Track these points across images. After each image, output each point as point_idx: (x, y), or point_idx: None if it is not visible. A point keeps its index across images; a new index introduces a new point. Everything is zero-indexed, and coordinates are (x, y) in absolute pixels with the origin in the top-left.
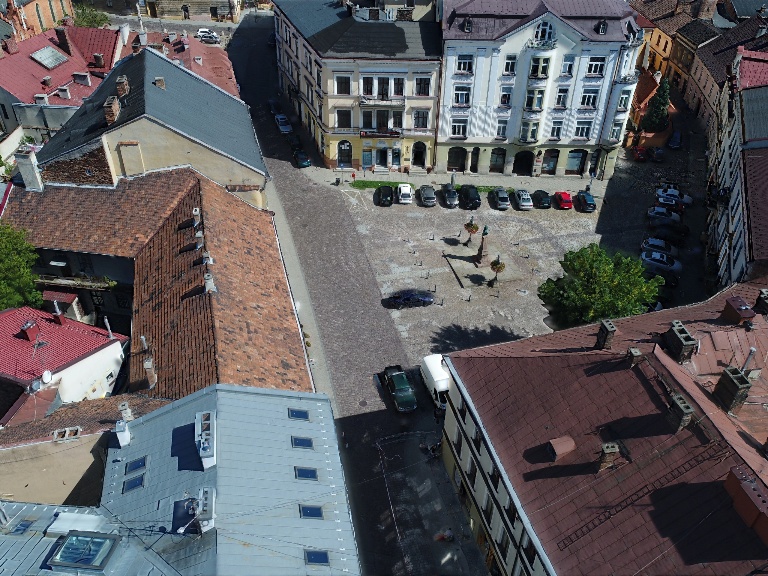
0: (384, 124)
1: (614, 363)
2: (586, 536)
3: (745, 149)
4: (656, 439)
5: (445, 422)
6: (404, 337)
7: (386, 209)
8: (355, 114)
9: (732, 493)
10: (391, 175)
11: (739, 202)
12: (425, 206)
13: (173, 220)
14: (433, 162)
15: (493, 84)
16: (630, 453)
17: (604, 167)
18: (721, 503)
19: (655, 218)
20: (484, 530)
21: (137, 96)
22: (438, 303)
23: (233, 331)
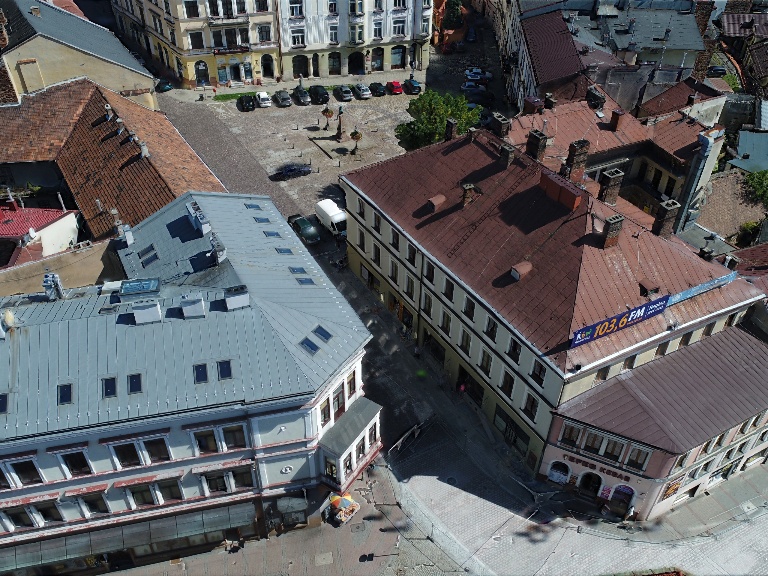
0: (233, 41)
1: (460, 143)
2: (464, 244)
3: (522, 19)
4: (496, 176)
5: (347, 234)
6: (295, 198)
7: (251, 113)
8: (206, 35)
9: (545, 187)
10: (247, 87)
11: (525, 57)
12: (283, 106)
13: (83, 122)
14: (281, 72)
15: None
16: (481, 189)
17: (421, 59)
18: (540, 196)
19: (467, 91)
20: (393, 293)
21: (20, 23)
22: (315, 172)
23: (175, 180)
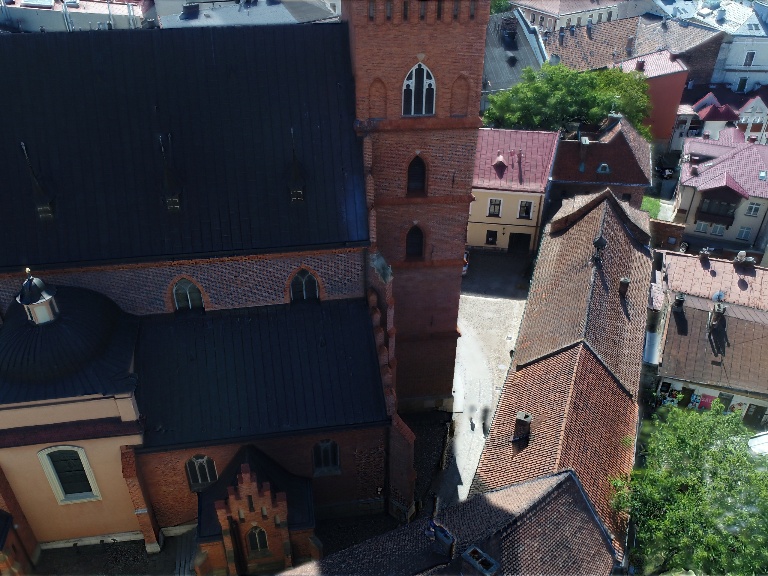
0: None
1: None
2: None
3: None
4: None
5: None
6: None
7: None
8: None
9: None
10: None
11: None
12: None
13: None
14: None
15: None
16: None
17: None
18: None
19: None
20: None
21: None
22: None
23: None
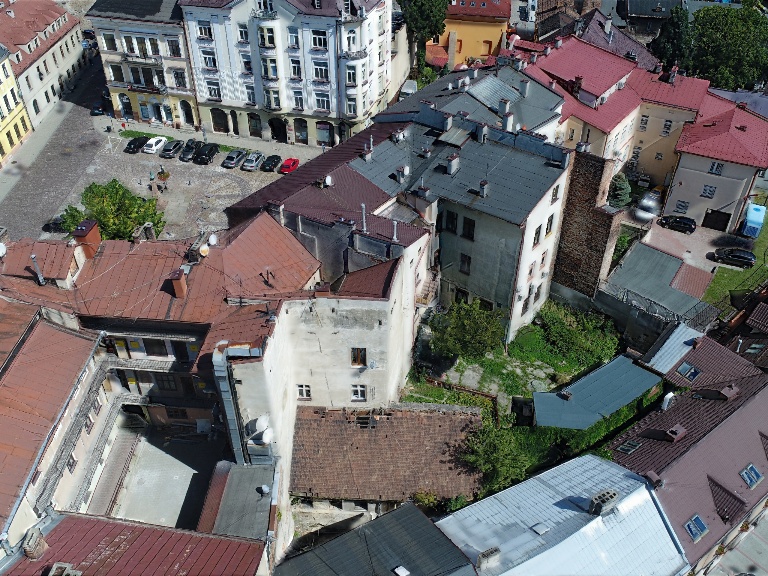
0: (151, 81)
1: None
2: None
3: (375, 123)
4: None
5: None
6: None
7: (129, 155)
8: (125, 69)
9: None
10: (163, 129)
11: None
12: (164, 157)
13: None
14: (199, 121)
15: (232, 50)
16: None
17: None
18: None
19: None
20: None
21: None
22: None
23: None
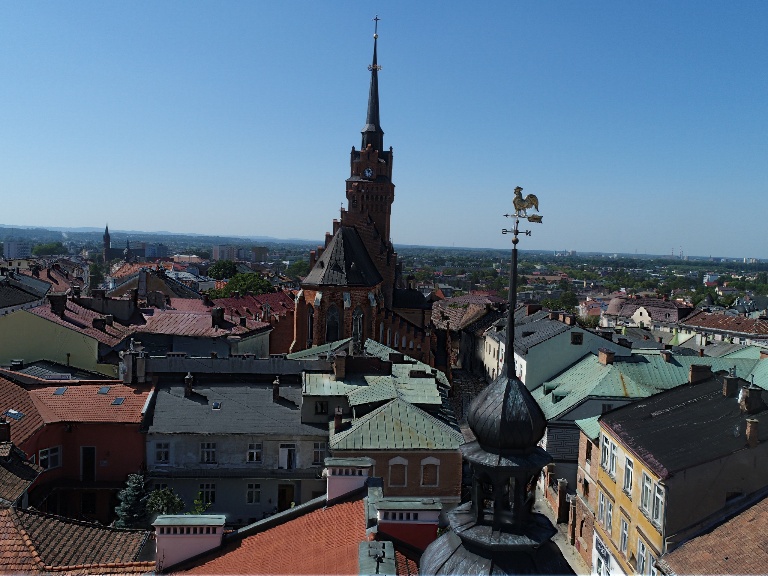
0: None
1: None
2: None
3: None
4: None
5: None
6: None
7: None
8: None
9: None
10: None
11: None
12: None
13: None
14: None
15: None
16: None
17: None
18: None
19: None
20: None
21: None
22: None
23: None
